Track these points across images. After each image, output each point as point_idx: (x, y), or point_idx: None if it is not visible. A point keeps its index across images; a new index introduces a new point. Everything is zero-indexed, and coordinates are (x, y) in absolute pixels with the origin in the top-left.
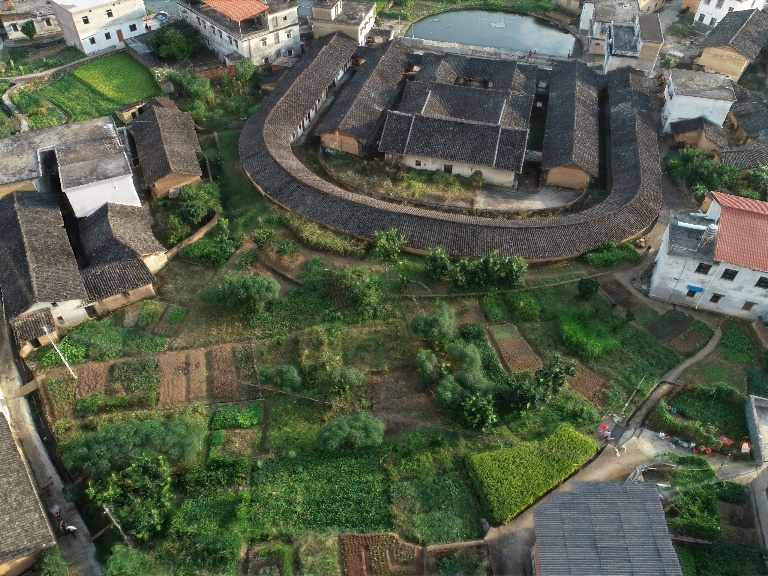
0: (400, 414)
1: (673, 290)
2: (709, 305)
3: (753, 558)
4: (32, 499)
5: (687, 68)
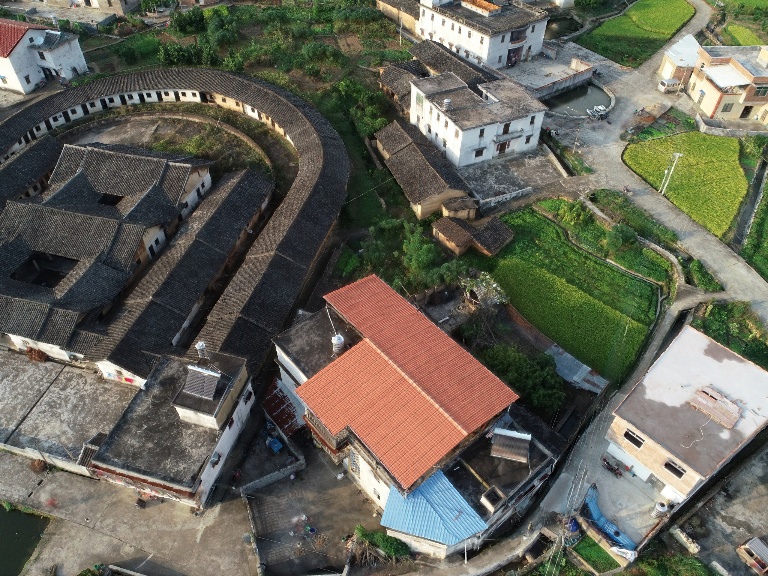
0: None
1: None
2: None
3: None
4: (386, 2)
5: None
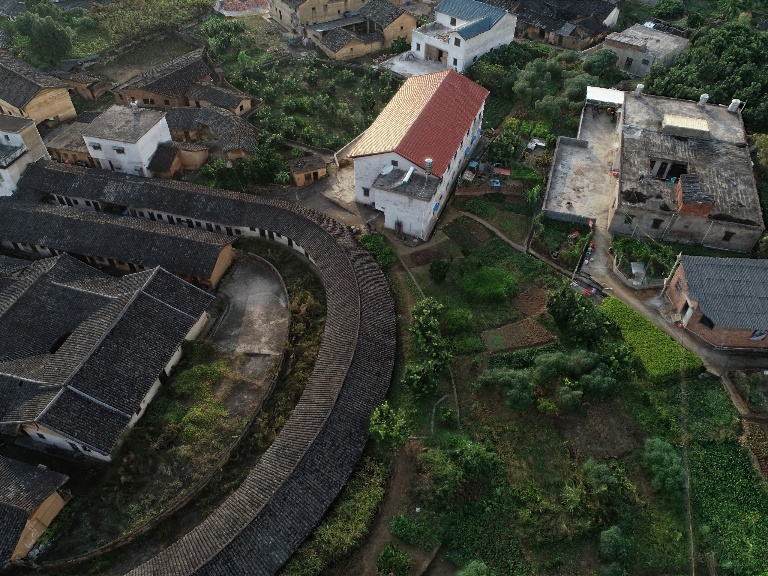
0: (616, 433)
1: (429, 222)
2: (438, 209)
3: (667, 244)
4: None
5: (43, 131)
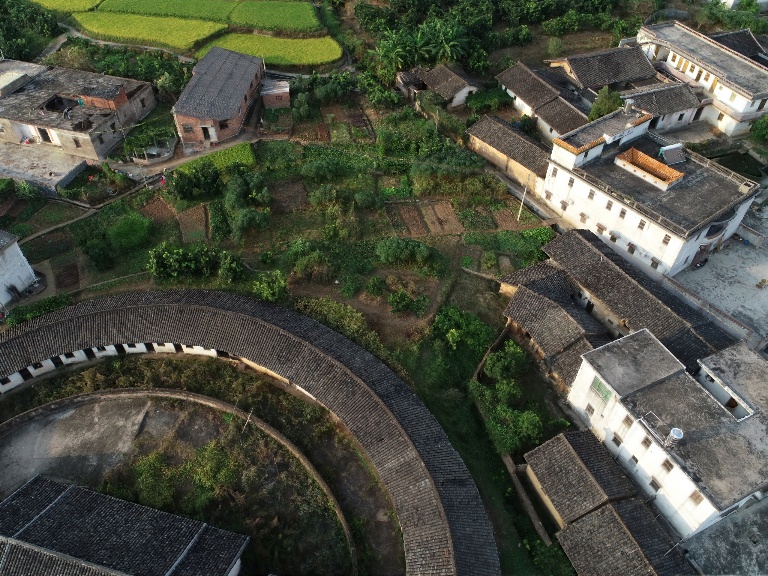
0: None
1: None
2: None
3: None
4: (487, 141)
5: None
